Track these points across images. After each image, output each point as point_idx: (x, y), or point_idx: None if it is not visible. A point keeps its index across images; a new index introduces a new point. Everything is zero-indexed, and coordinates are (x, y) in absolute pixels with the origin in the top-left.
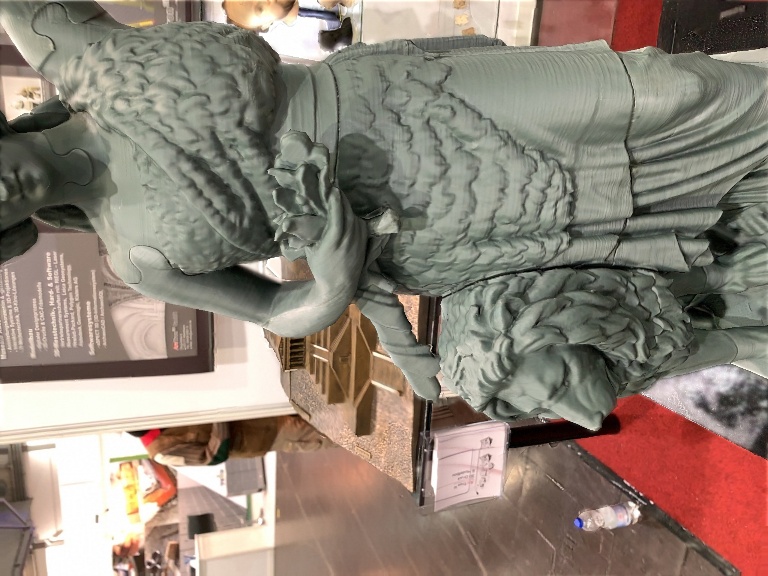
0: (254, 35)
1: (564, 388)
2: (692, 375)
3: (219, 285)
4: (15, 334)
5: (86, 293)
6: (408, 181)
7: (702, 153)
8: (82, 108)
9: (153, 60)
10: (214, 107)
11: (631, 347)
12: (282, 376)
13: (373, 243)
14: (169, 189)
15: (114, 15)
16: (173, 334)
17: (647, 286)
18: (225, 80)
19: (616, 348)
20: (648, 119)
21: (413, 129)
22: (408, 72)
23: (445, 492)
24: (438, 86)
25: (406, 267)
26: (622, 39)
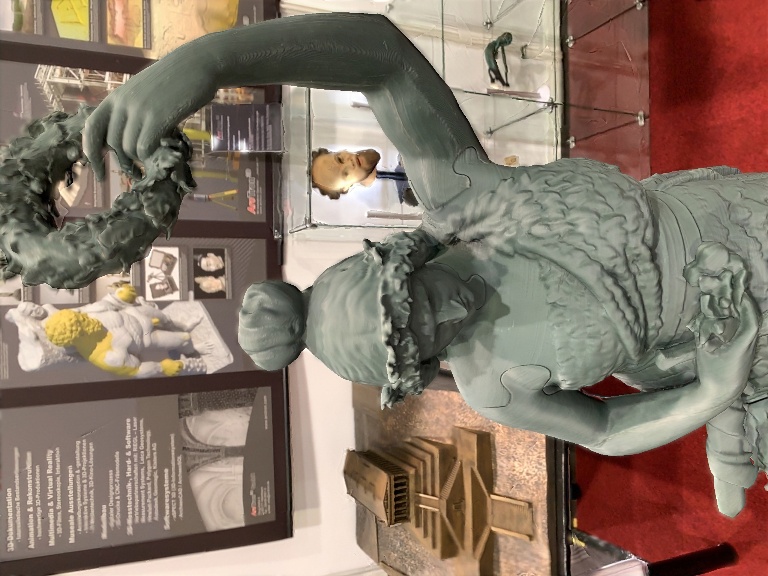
0: None
1: None
2: None
3: (571, 403)
4: (87, 512)
5: (164, 460)
6: (766, 286)
7: None
8: (480, 237)
9: (569, 189)
10: (629, 226)
11: None
12: (360, 536)
13: None
14: (580, 305)
15: (202, 186)
16: (251, 498)
17: None
18: (633, 202)
19: None
20: None
21: (760, 239)
22: (740, 192)
23: None
24: (766, 202)
25: (754, 370)
26: None
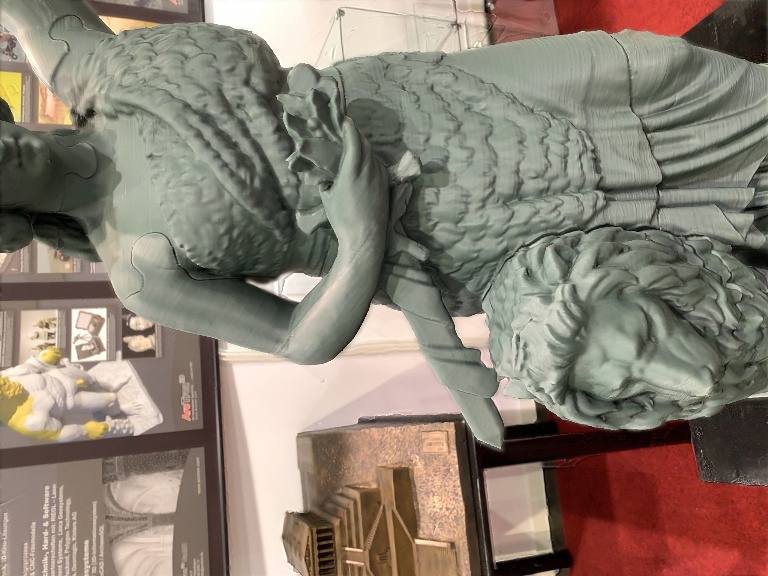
0: None
1: (652, 344)
2: None
3: (231, 291)
4: None
5: (85, 530)
6: (422, 136)
7: (710, 122)
8: (91, 106)
9: (161, 38)
10: (220, 65)
11: (713, 304)
12: None
13: (396, 193)
14: (175, 152)
15: None
16: (182, 572)
17: (705, 248)
18: (230, 44)
19: (697, 305)
20: (646, 75)
21: (419, 93)
22: (405, 56)
23: None
24: (436, 63)
25: (436, 237)
26: None
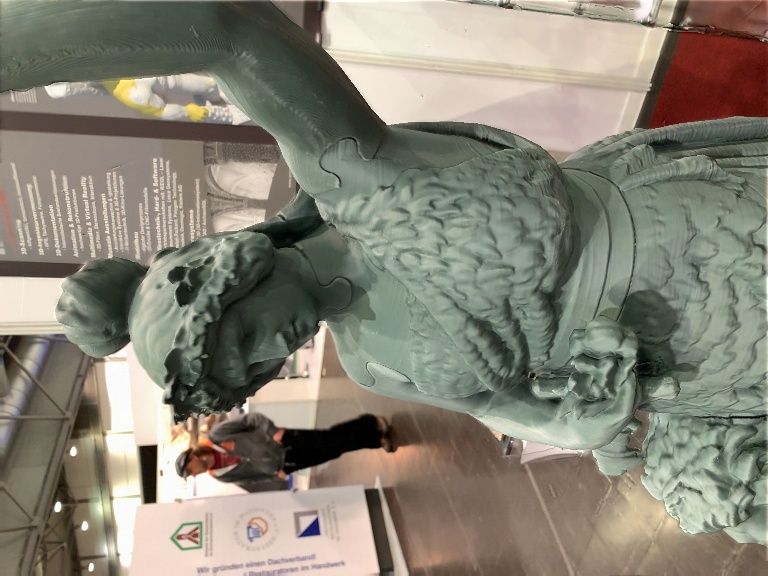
0: (553, 167)
1: None
2: None
3: None
4: (122, 235)
5: (190, 202)
6: (692, 341)
7: None
8: None
9: (456, 219)
10: (516, 278)
11: None
12: None
13: None
14: (442, 341)
15: None
16: None
17: None
18: (534, 249)
19: None
20: None
21: (712, 286)
22: (719, 218)
23: (533, 447)
24: (750, 236)
25: (652, 404)
26: None
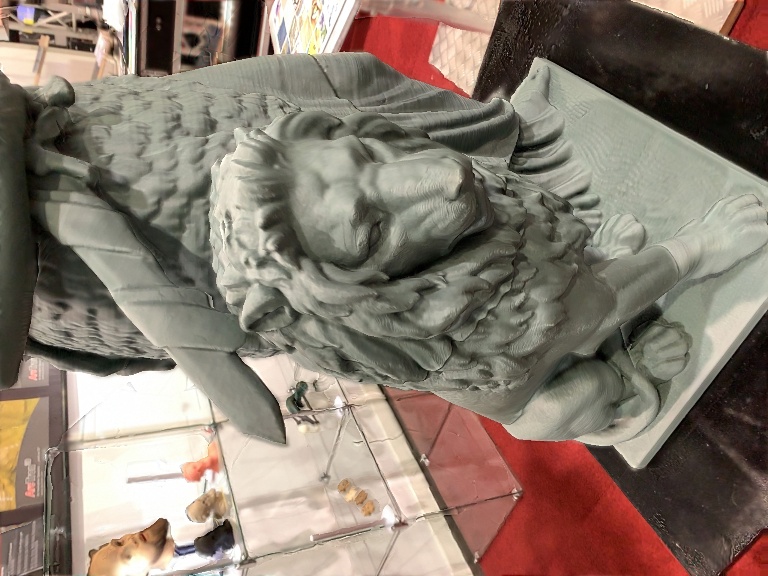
0: None
1: None
2: (739, 431)
3: None
4: None
5: None
6: (89, 96)
7: None
8: None
9: None
10: None
11: None
12: None
13: (42, 114)
14: None
15: None
16: None
17: None
18: None
19: None
20: (338, 69)
21: None
22: None
23: None
24: None
25: (114, 171)
26: (500, 435)
